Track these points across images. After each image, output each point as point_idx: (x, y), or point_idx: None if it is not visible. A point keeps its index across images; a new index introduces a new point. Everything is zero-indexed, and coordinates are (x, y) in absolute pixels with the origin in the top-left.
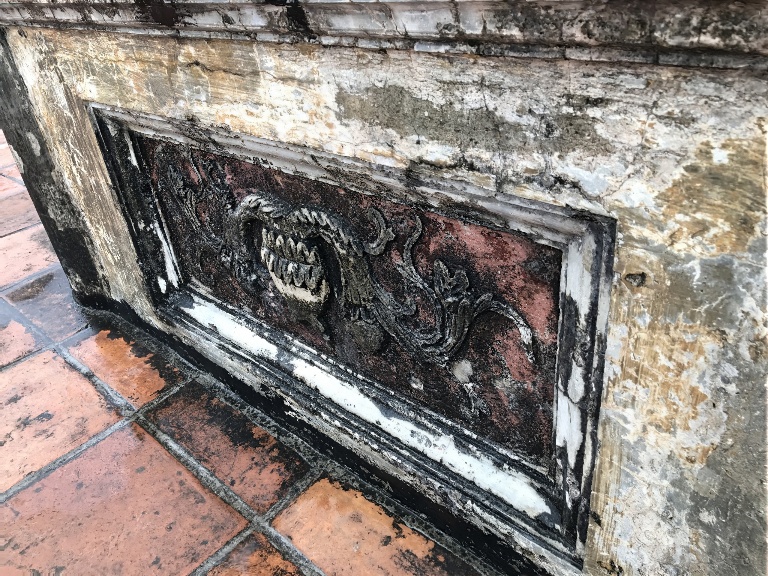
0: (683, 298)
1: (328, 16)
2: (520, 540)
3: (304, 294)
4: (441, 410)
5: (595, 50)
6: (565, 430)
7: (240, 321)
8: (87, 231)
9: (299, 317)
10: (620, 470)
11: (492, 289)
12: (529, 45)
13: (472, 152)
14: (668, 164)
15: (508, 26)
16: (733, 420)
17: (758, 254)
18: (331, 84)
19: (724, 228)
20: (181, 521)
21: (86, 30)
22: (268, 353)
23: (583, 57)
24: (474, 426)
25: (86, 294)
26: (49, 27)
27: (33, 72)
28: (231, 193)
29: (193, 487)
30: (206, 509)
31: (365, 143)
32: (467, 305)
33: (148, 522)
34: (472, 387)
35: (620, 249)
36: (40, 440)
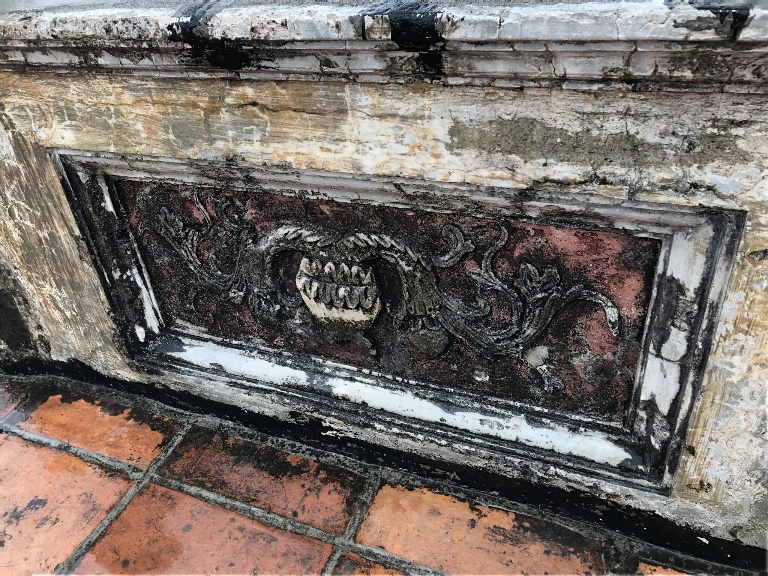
0: None
1: (472, 61)
2: (607, 487)
3: (354, 315)
4: (508, 395)
5: (754, 86)
6: (654, 386)
7: (252, 354)
8: (20, 290)
9: (340, 338)
10: (720, 406)
11: (582, 280)
12: (689, 82)
13: (606, 169)
14: None
15: (681, 69)
16: None
17: None
18: (445, 119)
19: None
20: (263, 565)
21: (72, 73)
22: (296, 380)
23: (741, 91)
24: (544, 402)
25: (14, 361)
26: (2, 70)
27: None
28: (253, 228)
29: (256, 529)
30: (282, 546)
31: (480, 169)
32: (557, 298)
33: (227, 575)
34: (546, 368)
35: (747, 234)
36: (47, 529)
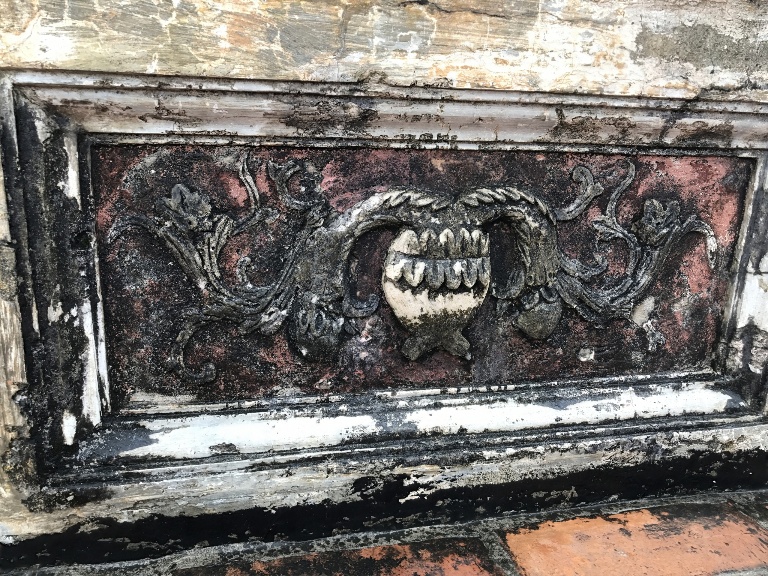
0: None
1: None
2: (723, 435)
3: (463, 301)
4: (611, 371)
5: None
6: (752, 307)
7: (282, 413)
8: None
9: (431, 345)
10: None
11: (693, 211)
12: None
13: (757, 74)
14: None
15: None
16: None
17: None
18: (635, 24)
19: None
20: None
21: None
22: (361, 428)
23: None
24: (644, 368)
25: None
26: None
27: None
28: (327, 203)
29: None
30: None
31: (659, 78)
32: (679, 231)
33: None
34: (651, 324)
35: None
36: None
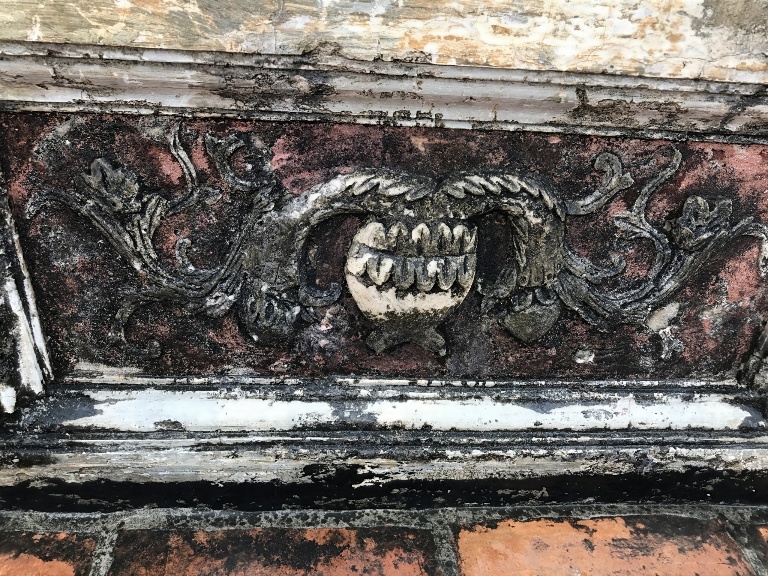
0: None
1: None
2: (729, 455)
3: (438, 300)
4: (612, 374)
5: None
6: None
7: (233, 393)
8: None
9: (399, 340)
10: None
11: (750, 212)
12: None
13: None
14: None
15: None
16: None
17: None
18: None
19: None
20: None
21: None
22: (316, 416)
23: None
24: (653, 373)
25: None
26: None
27: None
28: (279, 184)
29: None
30: None
31: (728, 57)
32: (724, 236)
33: None
34: (670, 330)
35: None
36: None
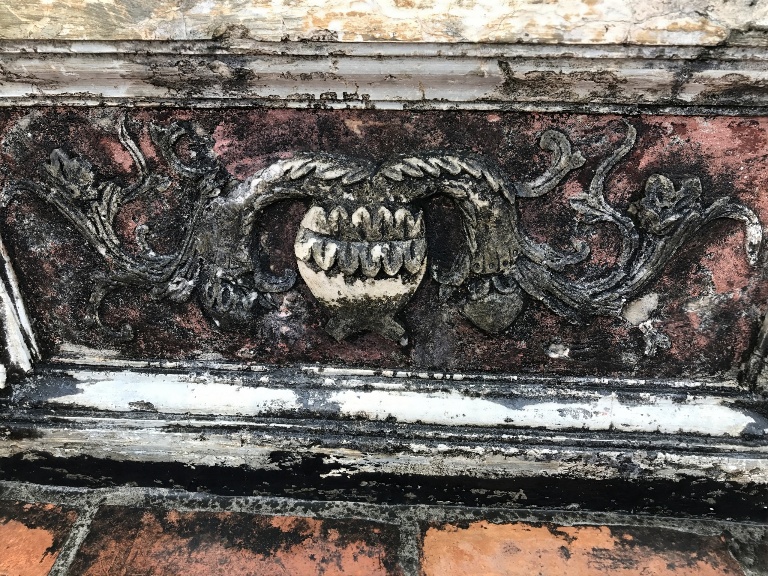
0: None
1: None
2: (729, 465)
3: (389, 287)
4: (591, 371)
5: None
6: None
7: (202, 378)
8: None
9: (356, 328)
10: None
11: (726, 191)
12: None
13: None
14: None
15: None
16: None
17: None
18: None
19: None
20: None
21: None
22: (280, 403)
23: None
24: (639, 371)
25: None
26: None
27: None
28: (223, 170)
29: None
30: None
31: (656, 17)
32: (696, 218)
33: None
34: (651, 324)
35: None
36: None
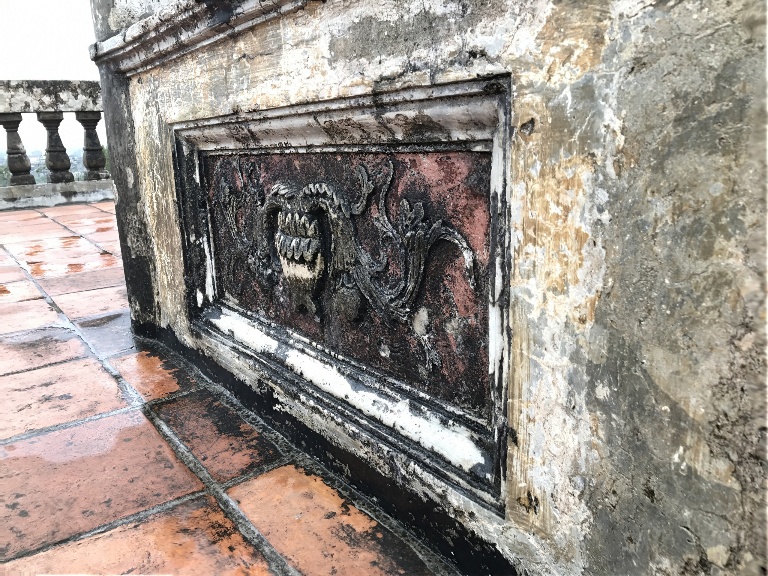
0: (561, 131)
1: None
2: (452, 497)
3: (302, 271)
4: (403, 376)
5: None
6: (494, 349)
7: (254, 324)
8: (153, 258)
9: (298, 301)
10: (529, 361)
11: (443, 216)
12: None
13: (415, 55)
14: (542, 3)
15: None
16: (610, 254)
17: (609, 61)
18: (327, 34)
19: (584, 46)
20: (144, 477)
21: (179, 57)
22: (269, 348)
23: None
24: (429, 387)
25: (141, 323)
26: (156, 65)
27: (141, 113)
28: (262, 190)
29: (167, 457)
30: (171, 473)
31: (346, 79)
32: (421, 236)
33: (115, 474)
34: (428, 338)
35: (515, 102)
36: (53, 411)
